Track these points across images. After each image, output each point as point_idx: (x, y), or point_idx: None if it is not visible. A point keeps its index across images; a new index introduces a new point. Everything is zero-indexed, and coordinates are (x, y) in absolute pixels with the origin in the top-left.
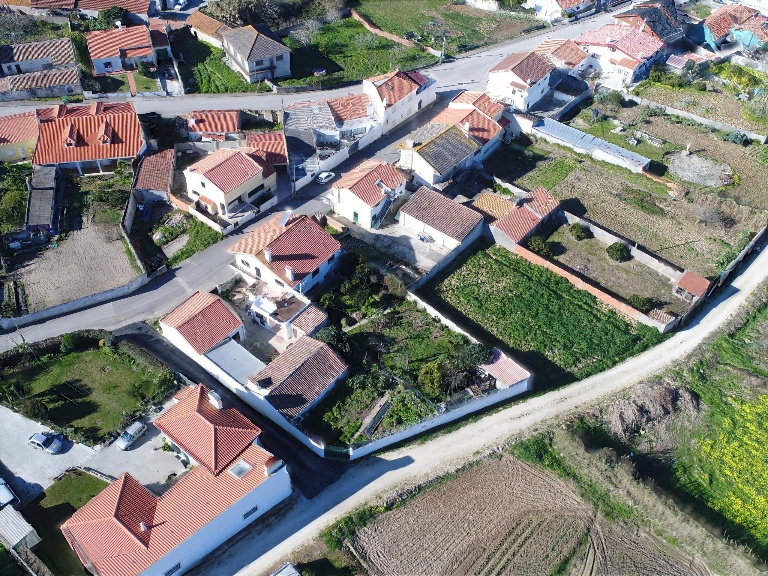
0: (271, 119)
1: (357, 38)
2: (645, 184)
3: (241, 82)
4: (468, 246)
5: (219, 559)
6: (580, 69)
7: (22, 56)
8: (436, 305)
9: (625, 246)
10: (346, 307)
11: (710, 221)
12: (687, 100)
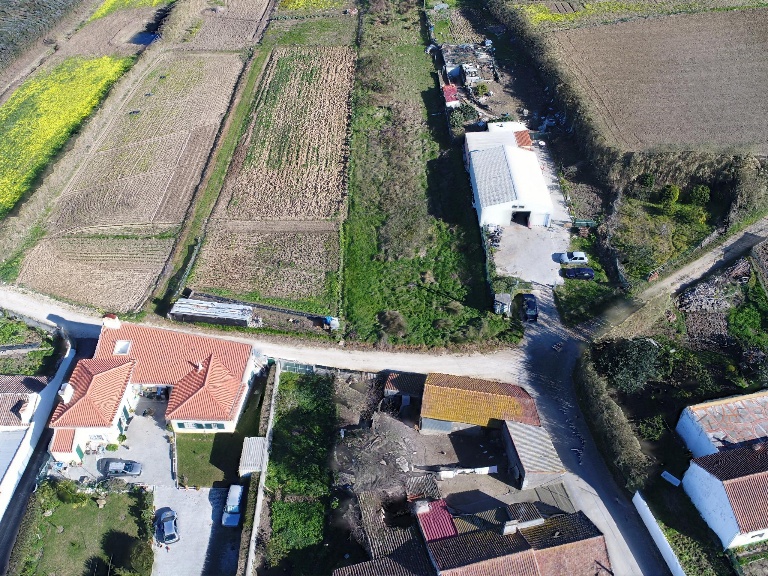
0: None
1: None
2: None
3: None
4: None
5: None
6: None
7: None
8: None
9: None
10: None
11: None
12: None
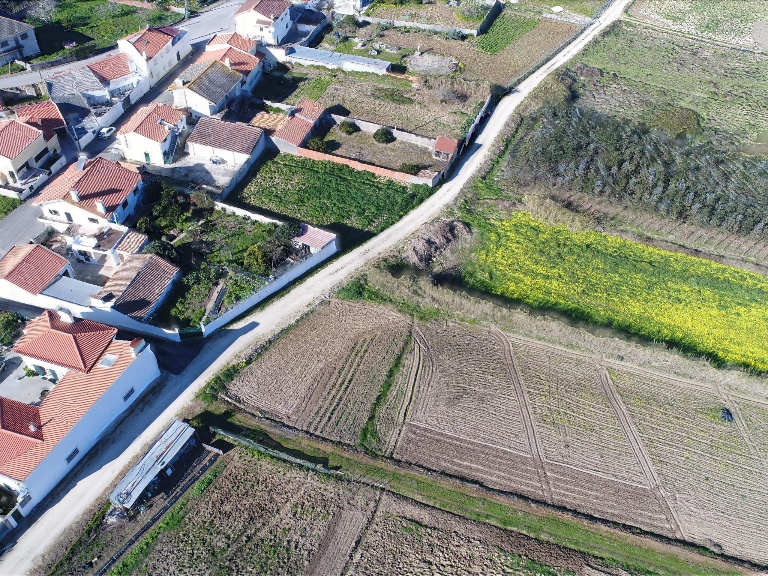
0: (34, 93)
1: (98, 9)
2: (392, 83)
3: None
4: (257, 158)
5: (112, 437)
6: (315, 3)
7: None
8: (243, 209)
9: (387, 130)
10: (162, 228)
11: (448, 99)
12: (410, 14)
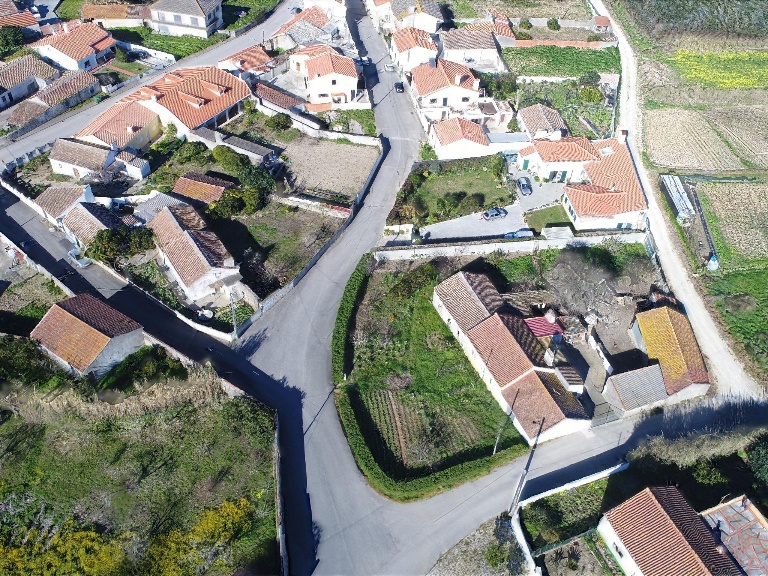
0: (270, 48)
1: None
2: None
3: (199, 40)
4: None
5: None
6: None
7: (8, 83)
8: None
9: (555, 20)
10: None
11: None
12: None
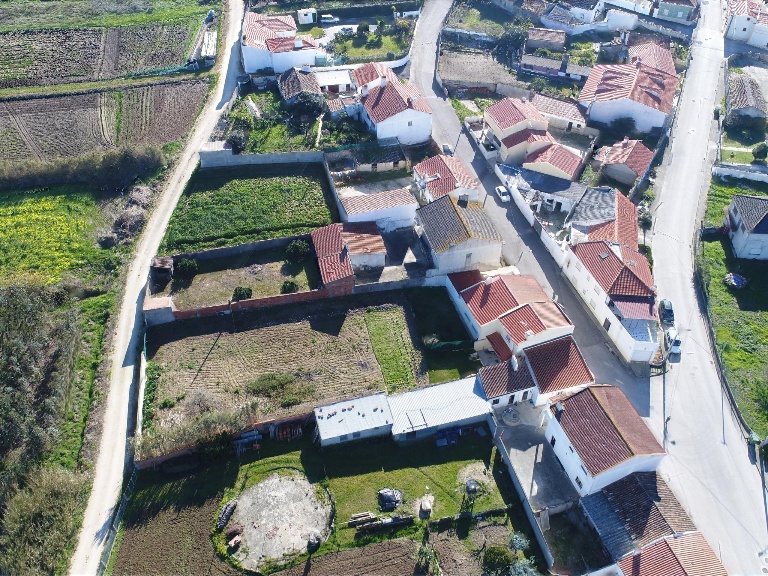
0: None
1: None
2: None
3: None
4: None
5: None
6: None
7: None
8: (304, 171)
9: (239, 297)
10: None
11: None
12: None
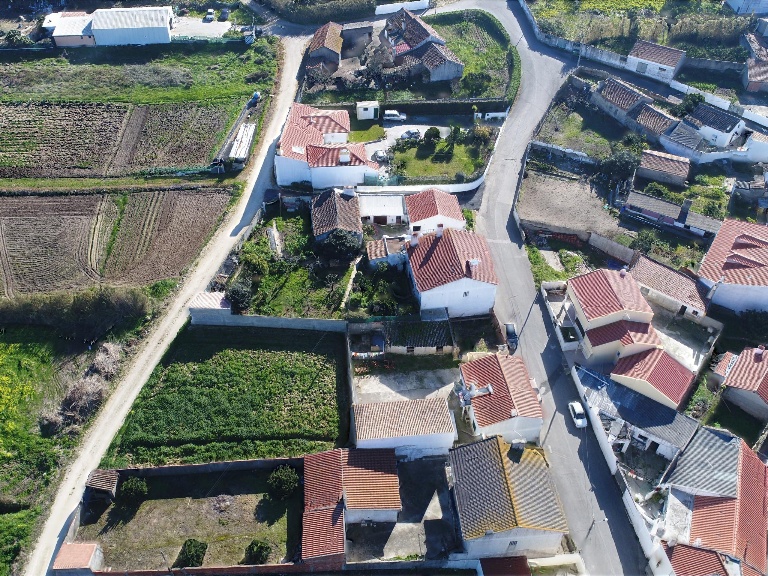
0: None
1: None
2: None
3: None
4: None
5: None
6: None
7: None
8: (319, 345)
9: (185, 560)
10: None
11: None
12: None
